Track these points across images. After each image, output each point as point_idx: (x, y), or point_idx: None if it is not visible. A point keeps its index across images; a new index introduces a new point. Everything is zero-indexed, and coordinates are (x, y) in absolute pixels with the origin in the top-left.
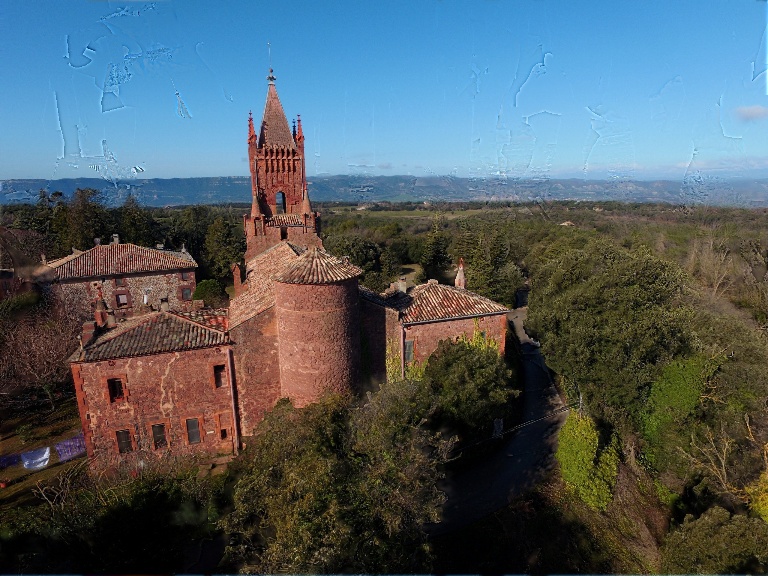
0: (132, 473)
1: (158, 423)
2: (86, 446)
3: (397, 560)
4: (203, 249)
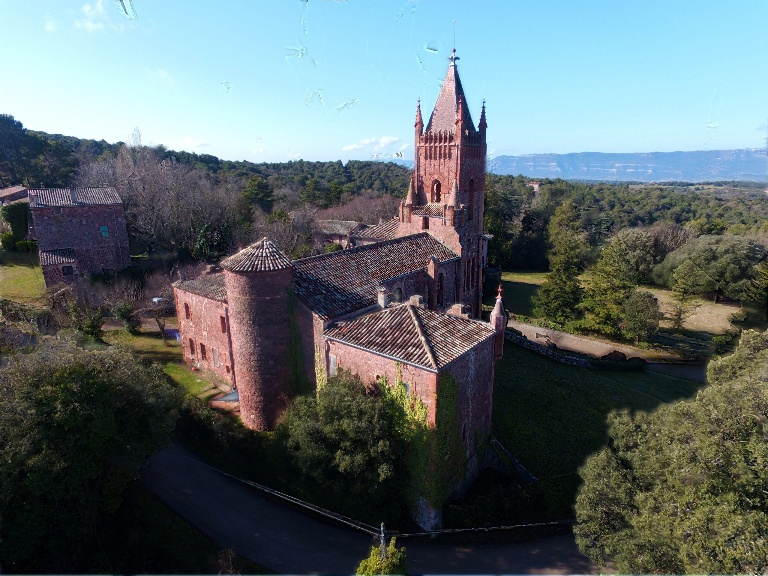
0: (5, 339)
1: (202, 342)
2: (181, 340)
3: (1, 468)
4: (546, 230)
